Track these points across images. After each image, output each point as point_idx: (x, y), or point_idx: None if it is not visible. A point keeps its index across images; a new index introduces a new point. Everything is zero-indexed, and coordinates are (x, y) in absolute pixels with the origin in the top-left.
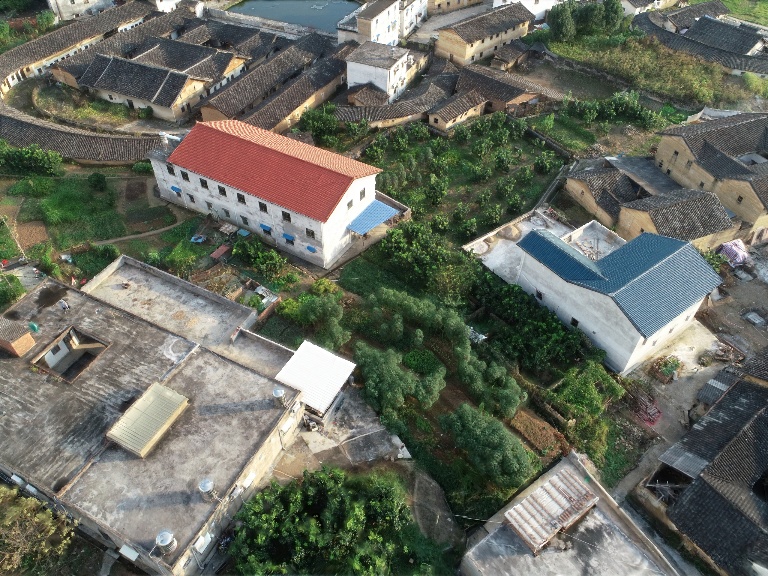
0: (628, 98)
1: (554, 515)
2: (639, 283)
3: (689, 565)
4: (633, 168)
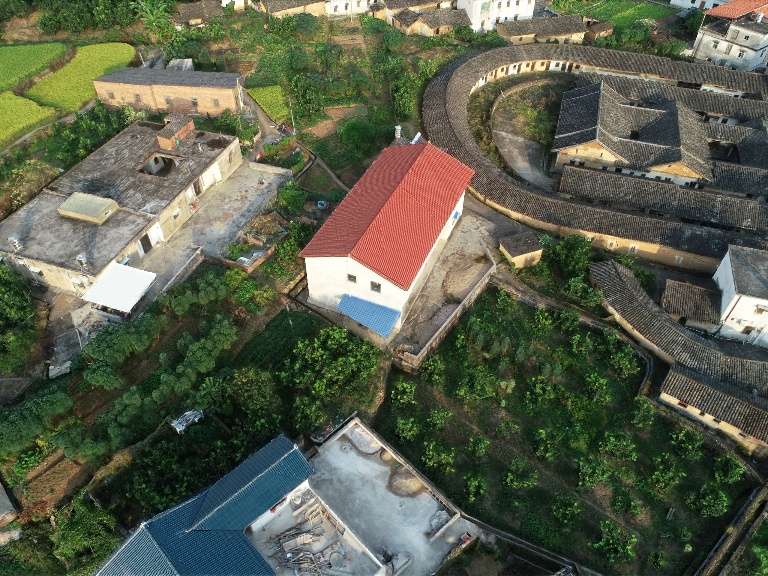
0: None
1: None
2: (166, 570)
3: None
4: None
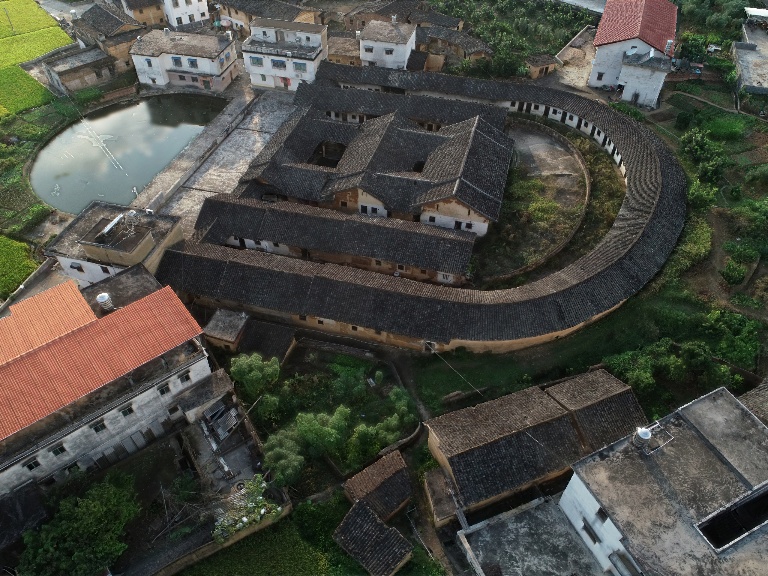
0: None
1: None
2: None
3: None
4: None
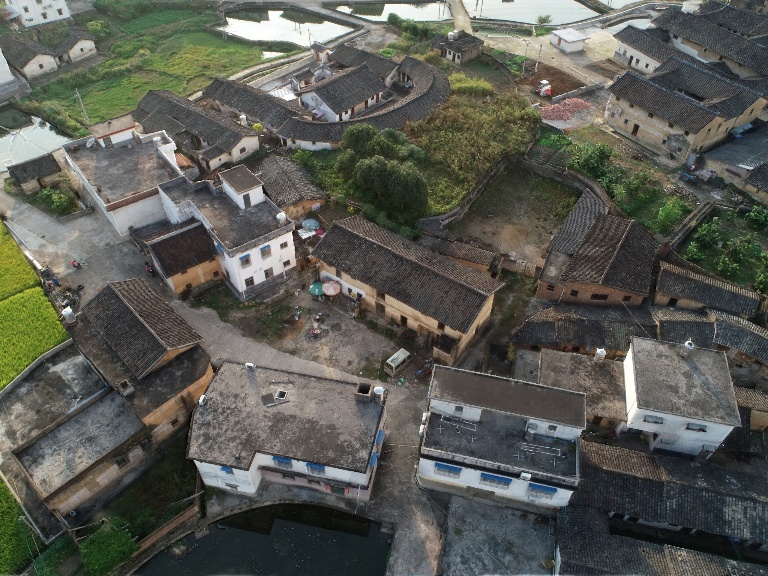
0: None
1: None
2: None
3: None
4: (744, 158)
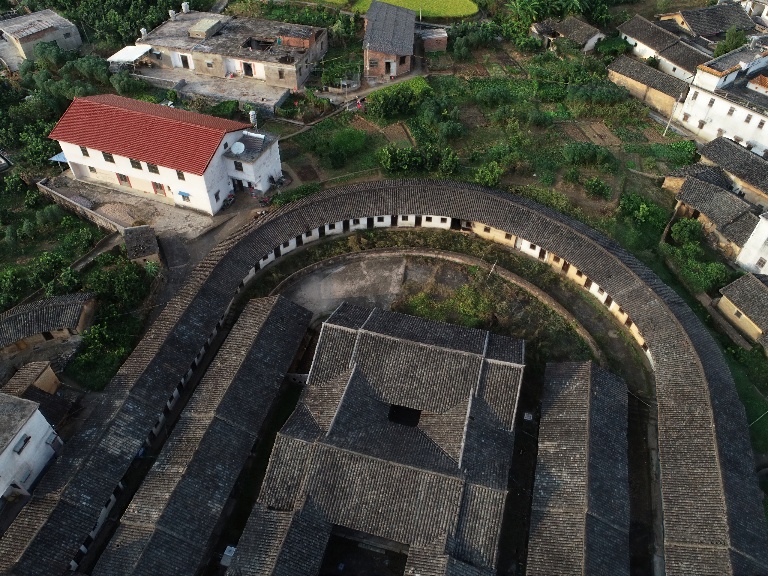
0: None
1: (33, 27)
2: None
3: None
4: None
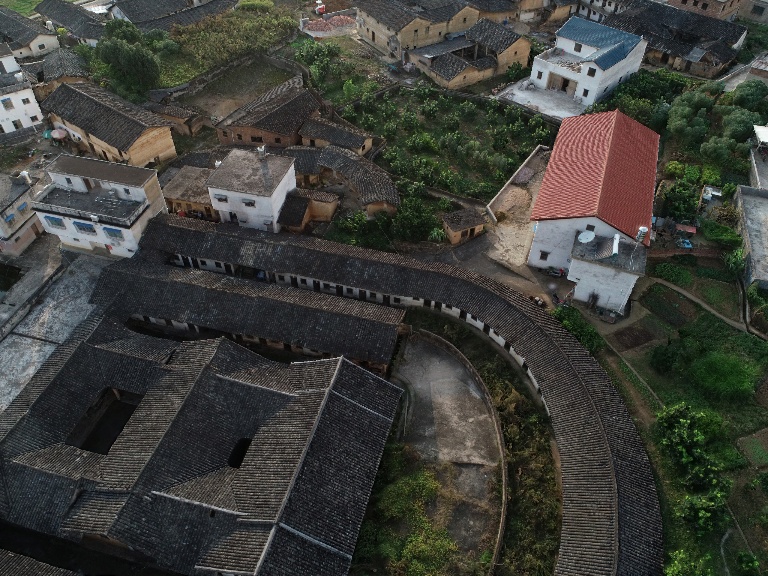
0: (308, 48)
1: None
2: None
3: (733, 68)
4: (434, 51)
